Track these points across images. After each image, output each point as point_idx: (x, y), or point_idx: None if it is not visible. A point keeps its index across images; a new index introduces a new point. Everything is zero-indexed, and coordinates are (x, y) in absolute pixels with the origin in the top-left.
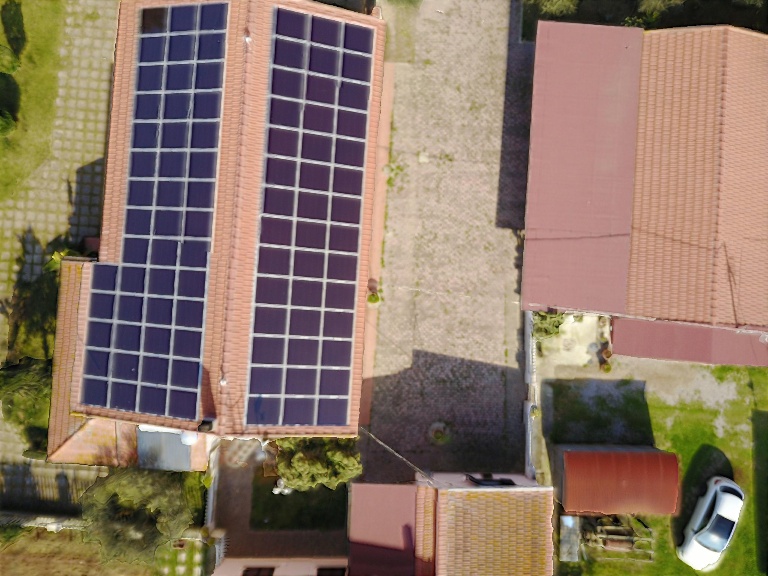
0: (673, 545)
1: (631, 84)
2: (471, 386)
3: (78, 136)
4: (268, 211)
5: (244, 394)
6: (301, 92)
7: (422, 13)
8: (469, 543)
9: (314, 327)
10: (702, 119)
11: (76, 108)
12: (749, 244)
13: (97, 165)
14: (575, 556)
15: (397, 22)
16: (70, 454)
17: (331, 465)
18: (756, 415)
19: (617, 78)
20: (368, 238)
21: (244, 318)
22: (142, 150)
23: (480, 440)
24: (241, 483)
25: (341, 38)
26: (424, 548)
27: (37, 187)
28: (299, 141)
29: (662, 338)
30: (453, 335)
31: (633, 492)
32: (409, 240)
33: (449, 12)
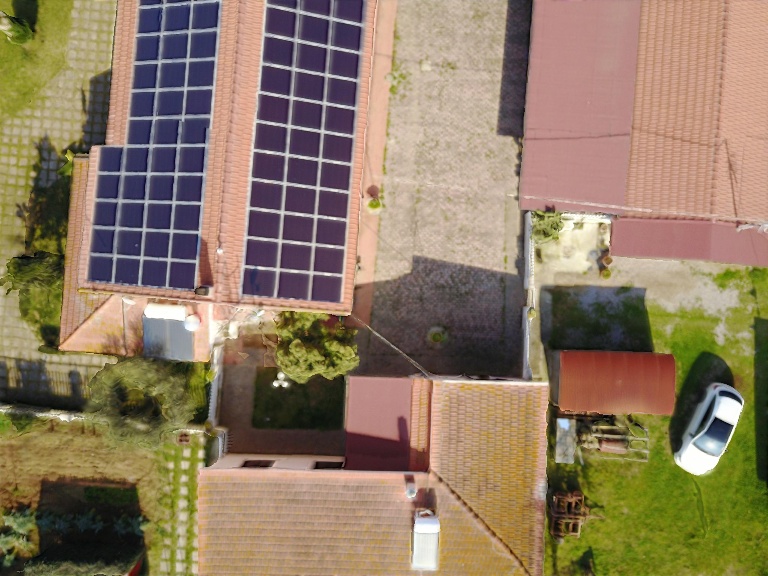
0: (671, 452)
1: None
2: (470, 292)
3: (91, 46)
4: (265, 89)
5: (240, 265)
6: None
7: None
8: (463, 434)
9: (309, 205)
10: (705, 16)
11: (90, 19)
12: (752, 143)
13: None
14: (571, 458)
15: None
16: (81, 342)
17: (329, 357)
18: (759, 324)
19: None
20: (363, 121)
21: (241, 192)
22: (146, 35)
23: (479, 345)
24: (245, 382)
25: None
26: (419, 439)
27: (53, 96)
28: (296, 22)
29: (661, 238)
30: (453, 241)
31: (629, 392)
32: (410, 147)
33: None
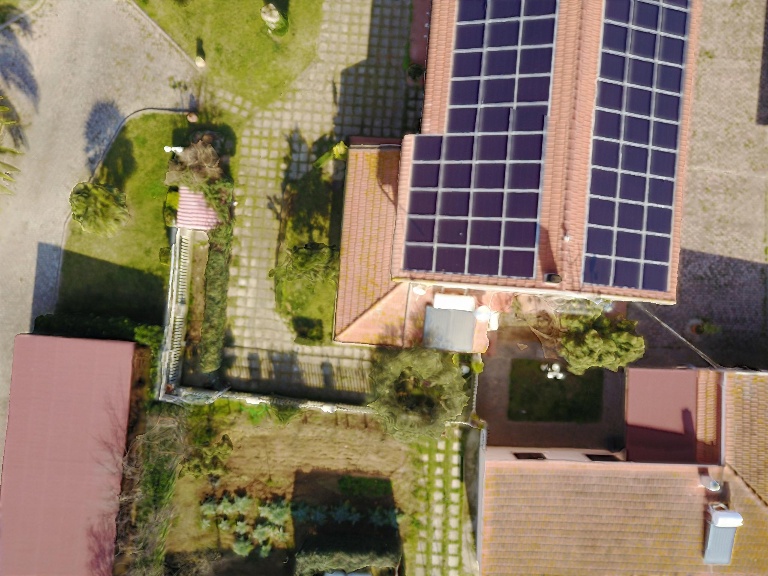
0: None
1: None
2: (730, 284)
3: (342, 39)
4: (603, 75)
5: (581, 253)
6: None
7: None
8: (756, 427)
9: (640, 193)
10: None
11: (341, 12)
12: None
13: (361, 66)
14: None
15: None
16: (358, 333)
17: None
18: None
19: None
20: None
21: (581, 179)
22: (468, 23)
23: (739, 338)
24: (499, 374)
25: None
26: (706, 432)
27: (304, 88)
28: (630, 8)
29: None
30: (712, 233)
31: None
32: None
33: None
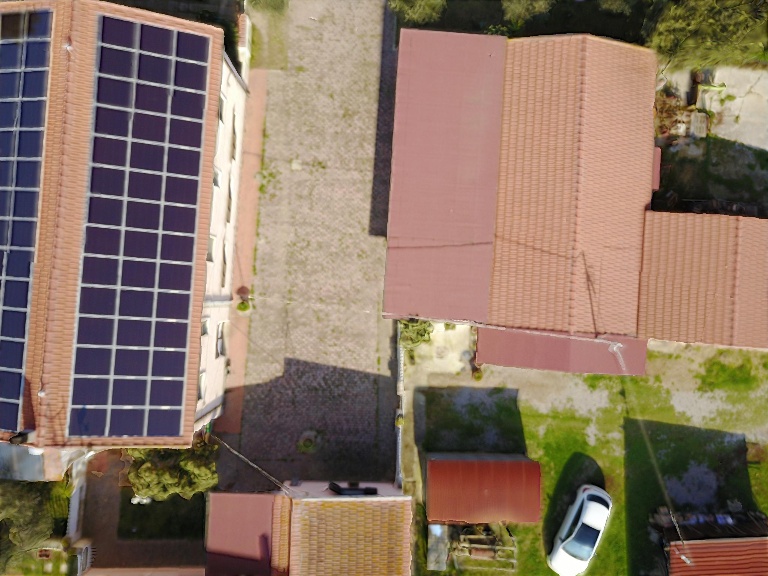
0: (544, 554)
1: (494, 92)
2: (343, 394)
3: None
4: (93, 221)
5: (66, 405)
6: (130, 101)
7: (295, 20)
8: (323, 553)
9: (144, 337)
10: (562, 128)
11: None
12: (610, 253)
13: None
14: (443, 565)
15: (270, 29)
16: None
17: (186, 475)
18: (628, 423)
19: (480, 86)
20: (204, 248)
21: (67, 329)
22: None
23: (352, 448)
24: (109, 492)
25: (173, 47)
26: (280, 558)
27: None
28: (128, 150)
29: (523, 347)
30: (325, 343)
31: (495, 501)
32: (281, 248)
33: (322, 19)
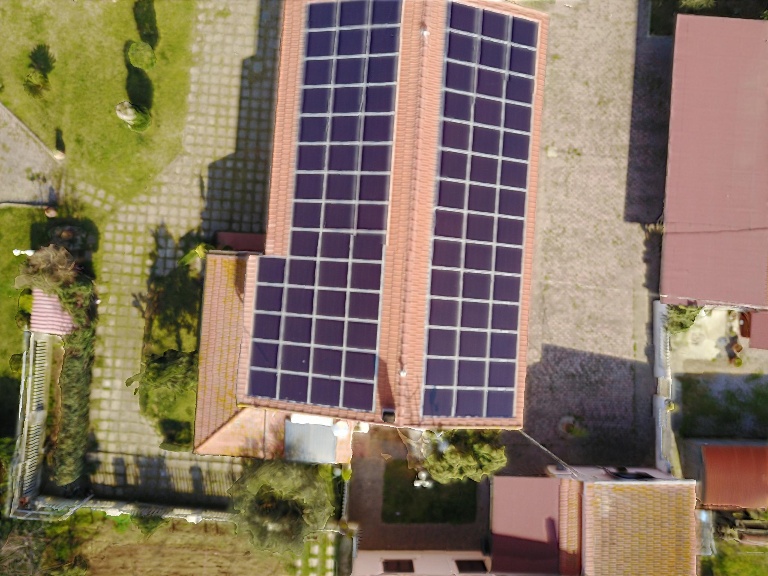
0: None
1: None
2: (600, 380)
3: (210, 131)
4: (442, 204)
5: (420, 385)
6: (472, 85)
7: (550, 7)
8: (615, 536)
9: (483, 319)
10: None
11: (208, 103)
12: None
13: (229, 160)
14: (709, 550)
15: None
16: (217, 446)
17: (475, 457)
18: None
19: (756, 71)
20: (532, 231)
21: (420, 310)
22: (310, 144)
23: (609, 434)
24: (373, 476)
25: (509, 32)
26: (568, 540)
27: (170, 182)
28: (470, 134)
29: None
30: (582, 329)
31: None
32: (538, 234)
33: (577, 6)
